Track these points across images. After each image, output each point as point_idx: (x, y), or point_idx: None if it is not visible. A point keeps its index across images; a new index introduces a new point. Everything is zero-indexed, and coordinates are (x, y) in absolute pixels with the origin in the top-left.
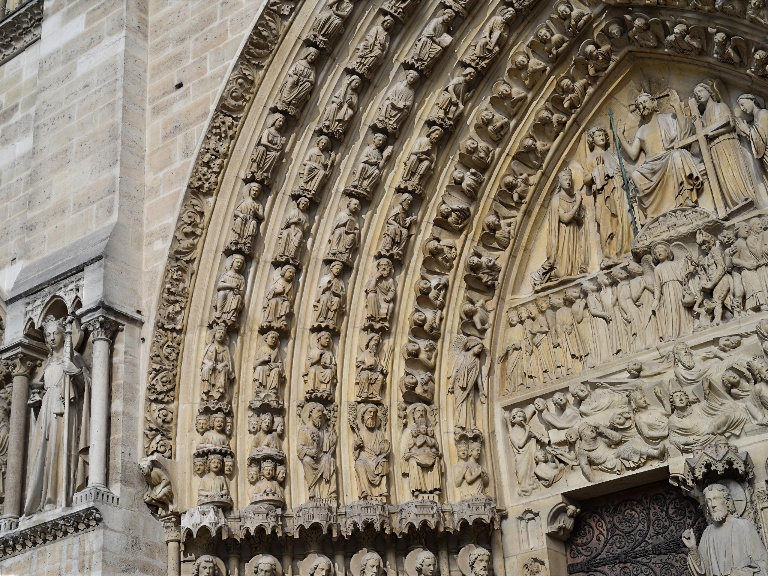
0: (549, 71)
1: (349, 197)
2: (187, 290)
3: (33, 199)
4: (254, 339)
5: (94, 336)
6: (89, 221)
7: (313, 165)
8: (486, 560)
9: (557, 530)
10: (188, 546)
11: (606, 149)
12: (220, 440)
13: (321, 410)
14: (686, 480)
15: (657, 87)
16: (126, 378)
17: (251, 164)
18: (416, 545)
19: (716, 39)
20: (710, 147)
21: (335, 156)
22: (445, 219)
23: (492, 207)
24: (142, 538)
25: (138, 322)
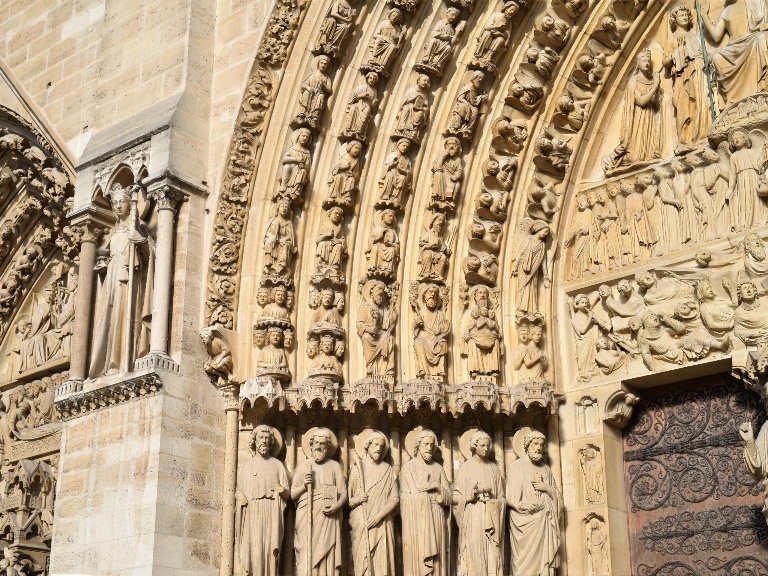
0: None
1: (419, 73)
2: (253, 163)
3: (104, 66)
4: (318, 214)
5: (159, 205)
6: (158, 90)
7: (383, 39)
8: (541, 443)
9: (614, 417)
10: (246, 415)
11: (689, 30)
12: (280, 313)
13: (382, 288)
14: (748, 373)
15: None
16: (190, 248)
17: (320, 36)
18: (471, 425)
19: None
20: None
21: (406, 30)
22: (517, 98)
23: (566, 87)
24: (201, 405)
25: (203, 193)
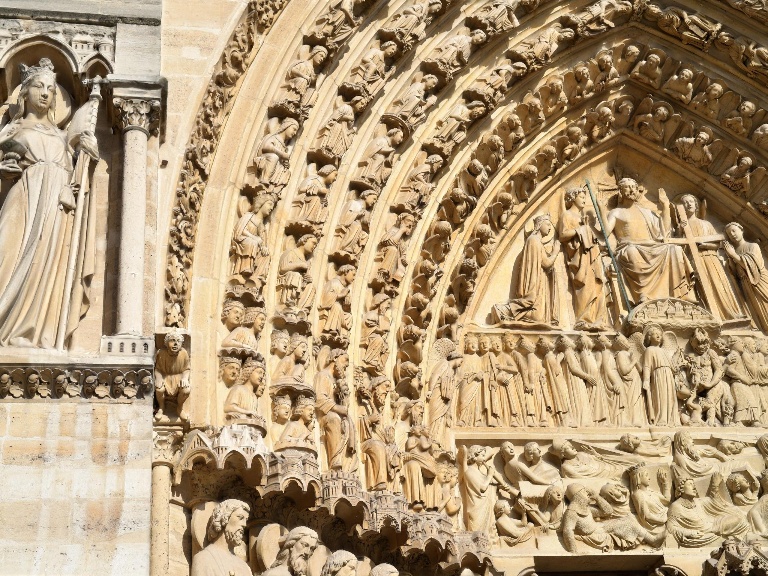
0: (565, 110)
1: (387, 126)
2: (220, 130)
3: None
4: (280, 235)
5: (133, 122)
6: None
7: None
8: None
9: None
10: None
11: None
12: (255, 345)
13: None
14: (718, 573)
15: None
16: None
17: (325, 24)
18: (407, 571)
19: (746, 161)
20: None
21: (394, 72)
22: (453, 204)
23: (482, 216)
24: None
25: (161, 136)
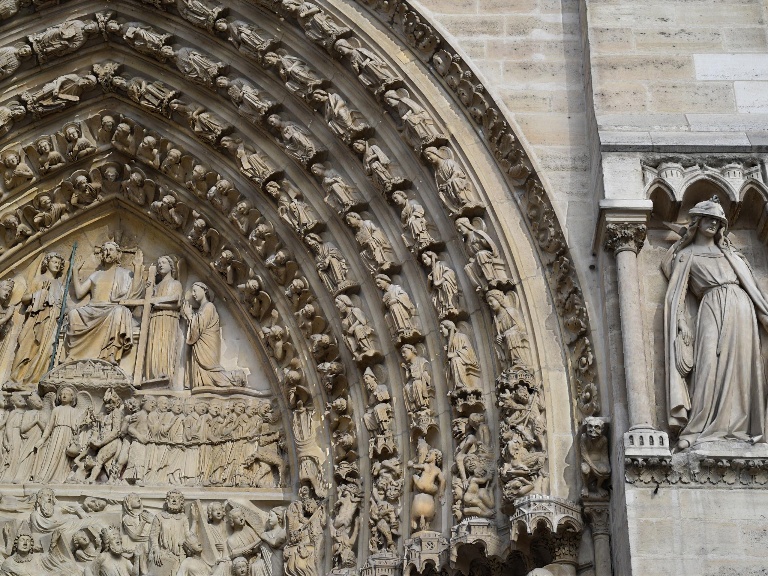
0: (34, 181)
1: None
2: None
3: None
4: None
5: None
6: None
7: None
8: None
9: None
10: None
11: (57, 277)
12: None
13: None
14: None
15: (128, 241)
16: None
17: None
18: None
19: (196, 223)
20: (152, 316)
21: None
22: None
23: None
24: None
25: None
